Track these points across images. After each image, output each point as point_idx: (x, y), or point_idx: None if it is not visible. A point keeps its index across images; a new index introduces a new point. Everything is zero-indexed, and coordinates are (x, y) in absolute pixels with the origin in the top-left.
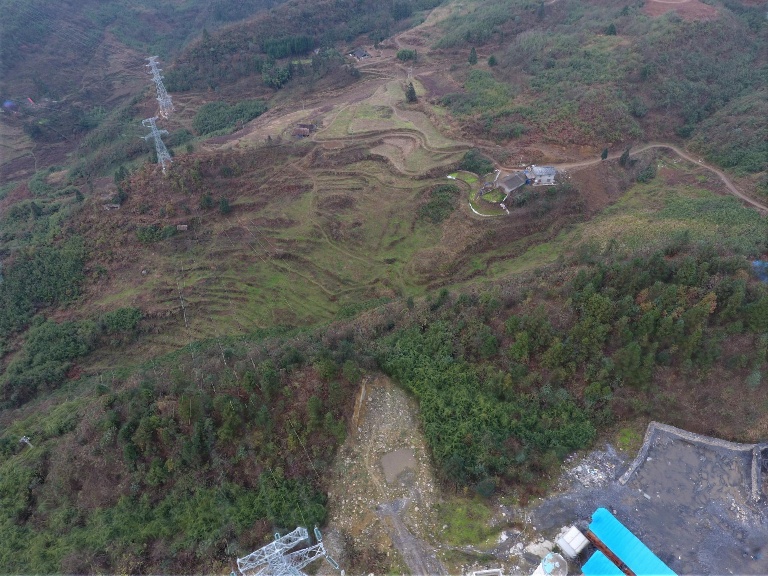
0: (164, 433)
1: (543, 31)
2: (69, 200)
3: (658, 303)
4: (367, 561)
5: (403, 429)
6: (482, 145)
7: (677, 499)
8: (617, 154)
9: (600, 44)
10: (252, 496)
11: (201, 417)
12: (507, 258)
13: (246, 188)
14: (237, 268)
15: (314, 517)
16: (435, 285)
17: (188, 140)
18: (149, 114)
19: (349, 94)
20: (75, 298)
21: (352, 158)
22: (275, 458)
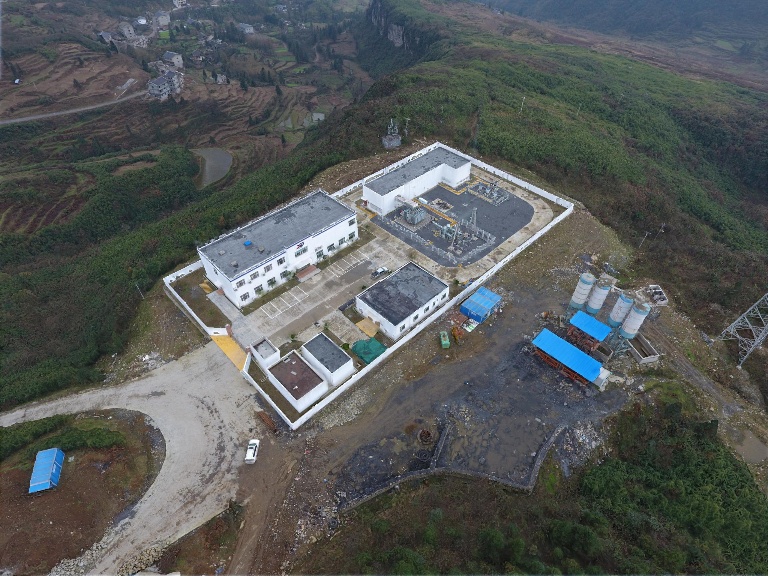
0: None
1: None
2: None
3: None
4: None
5: None
6: None
7: (513, 420)
8: None
9: None
10: None
11: None
12: None
13: None
14: None
15: None
16: None
17: None
18: None
19: None
20: None
21: None
22: None
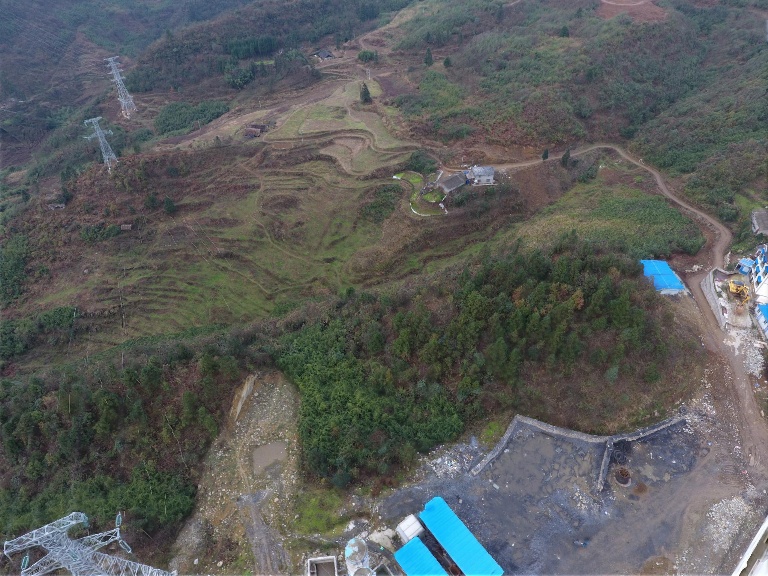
0: (45, 428)
1: (499, 33)
2: (16, 200)
3: (530, 300)
4: (219, 550)
5: (282, 423)
6: (430, 146)
7: (524, 489)
8: (560, 155)
9: (552, 46)
10: (124, 488)
11: (82, 412)
12: (443, 257)
13: (193, 188)
14: (179, 267)
15: (177, 508)
16: (370, 284)
17: (134, 140)
18: (112, 114)
19: (309, 95)
20: (16, 297)
21: (301, 158)
22: (150, 451)
